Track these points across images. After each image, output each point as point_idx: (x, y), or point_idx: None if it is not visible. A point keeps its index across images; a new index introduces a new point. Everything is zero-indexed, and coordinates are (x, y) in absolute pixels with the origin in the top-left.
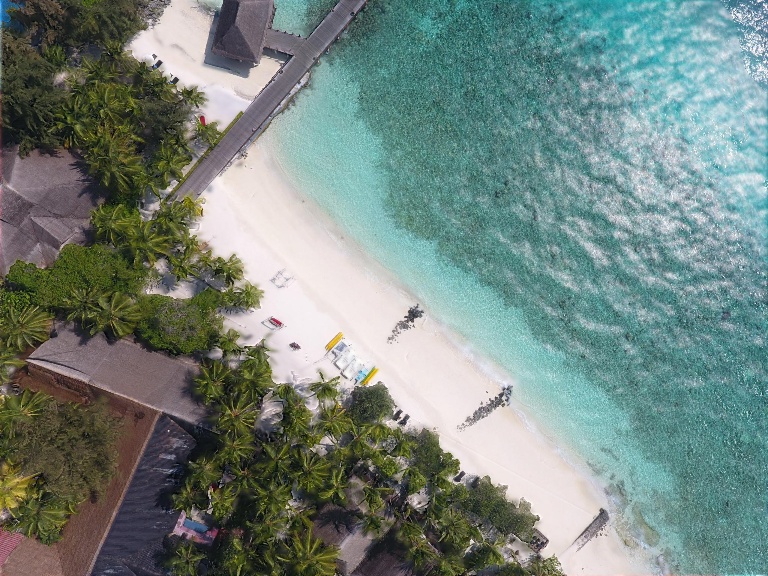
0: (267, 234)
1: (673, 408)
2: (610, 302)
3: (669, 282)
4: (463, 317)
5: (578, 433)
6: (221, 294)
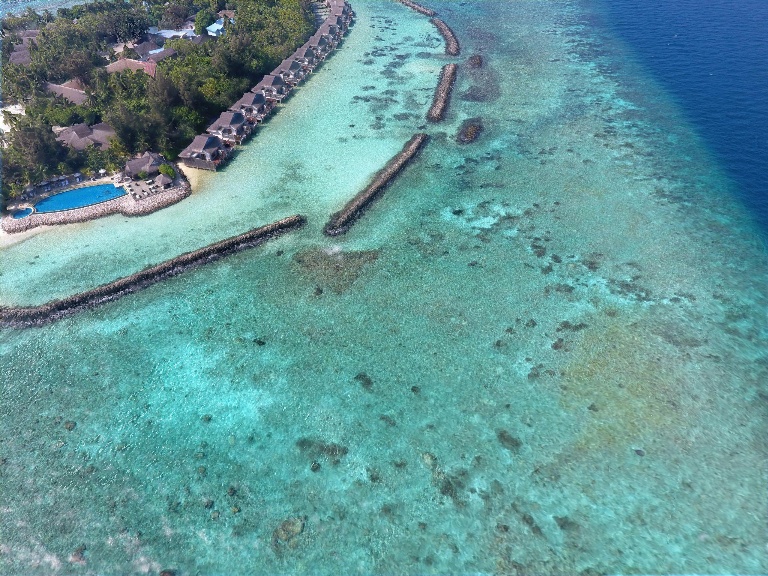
0: None
1: None
2: None
3: None
4: None
5: None
6: None
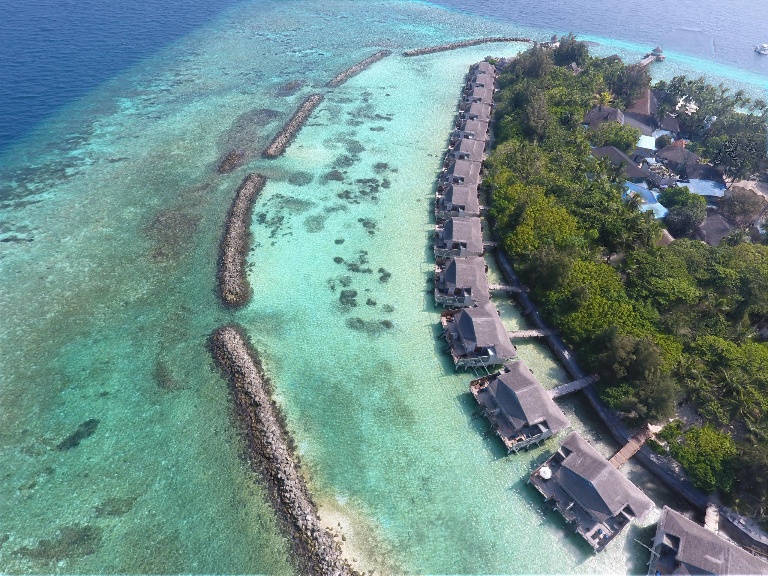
0: None
1: None
2: None
3: None
4: None
5: None
6: None
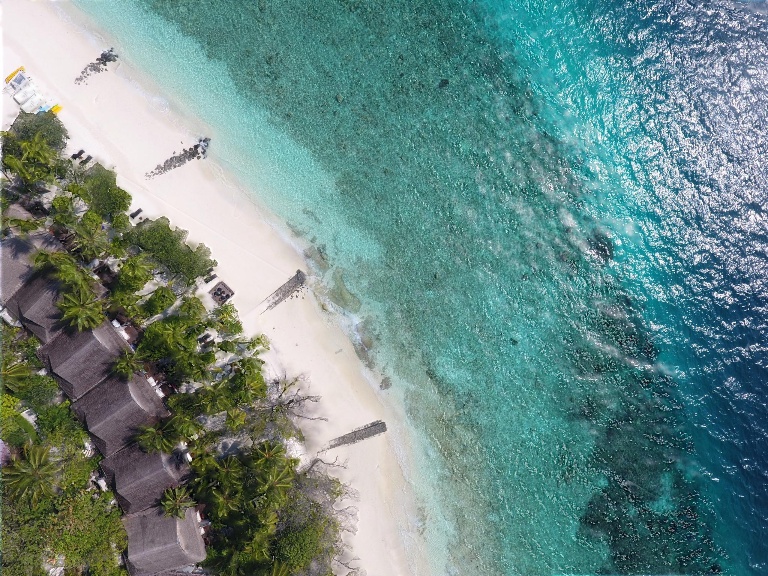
0: None
1: (383, 174)
2: (321, 61)
3: (385, 45)
4: (162, 66)
5: (279, 193)
6: None
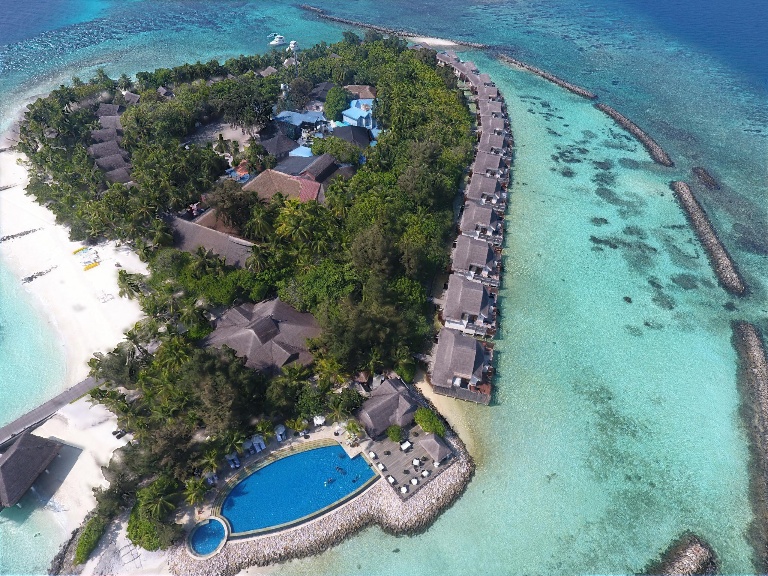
0: (102, 325)
1: None
2: None
3: None
4: None
5: None
6: (144, 283)
